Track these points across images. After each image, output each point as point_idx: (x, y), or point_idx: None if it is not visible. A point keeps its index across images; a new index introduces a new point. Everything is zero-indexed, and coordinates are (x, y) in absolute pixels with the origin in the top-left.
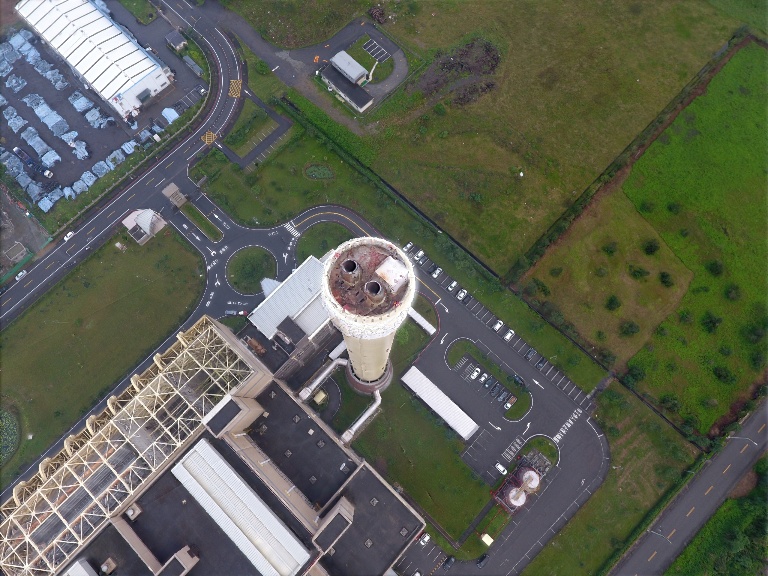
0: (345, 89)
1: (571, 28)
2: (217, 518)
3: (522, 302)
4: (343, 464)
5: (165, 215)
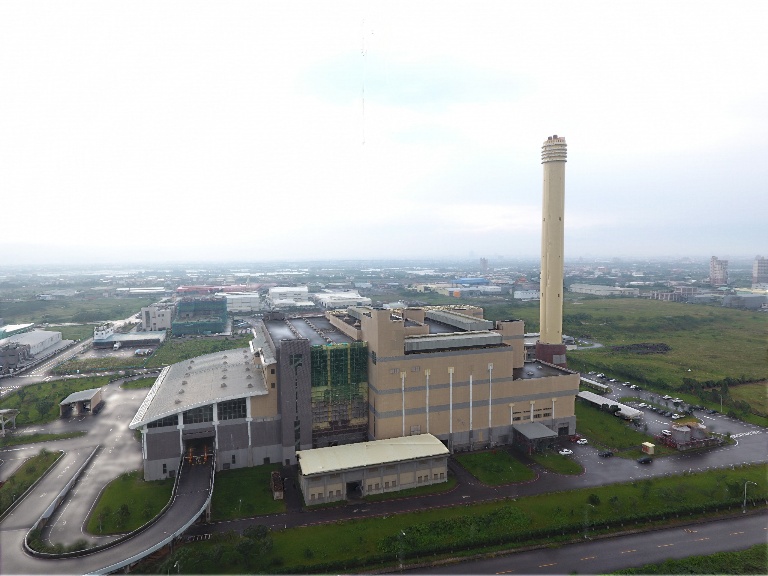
0: None
1: (729, 350)
2: (444, 315)
3: None
4: None
5: None
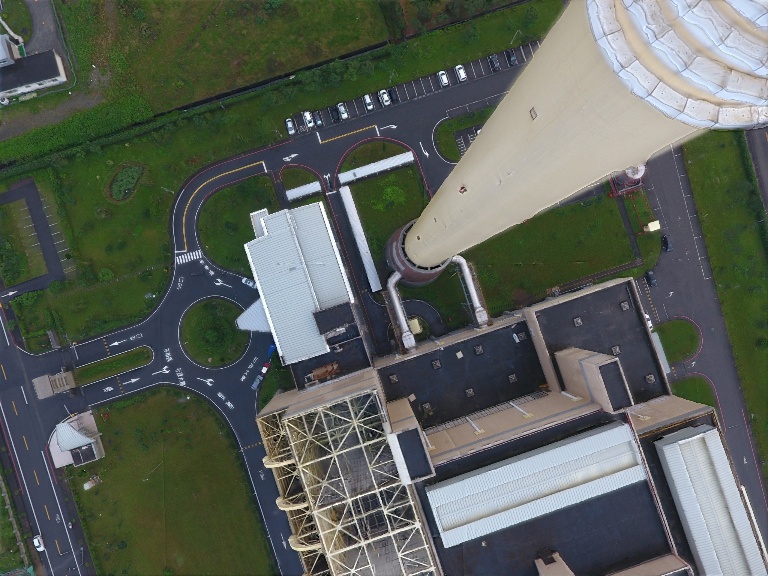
0: (16, 80)
1: None
2: (530, 515)
3: (432, 34)
4: (514, 336)
5: (77, 408)
